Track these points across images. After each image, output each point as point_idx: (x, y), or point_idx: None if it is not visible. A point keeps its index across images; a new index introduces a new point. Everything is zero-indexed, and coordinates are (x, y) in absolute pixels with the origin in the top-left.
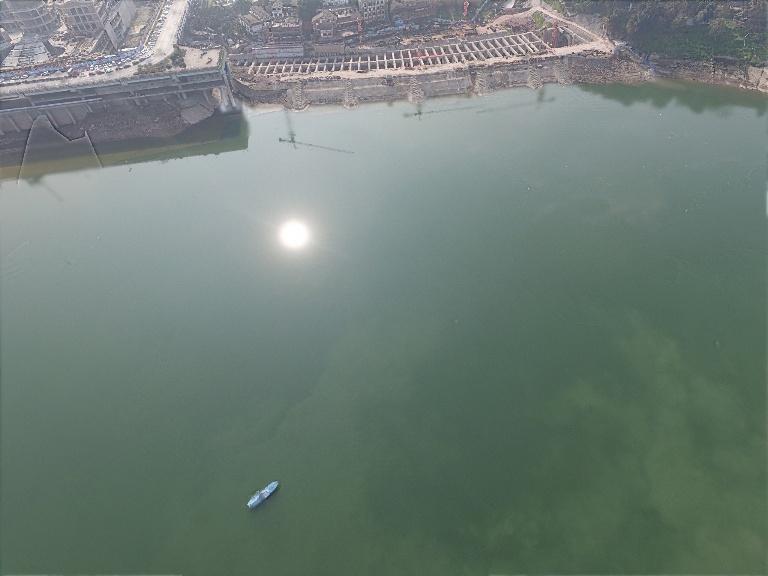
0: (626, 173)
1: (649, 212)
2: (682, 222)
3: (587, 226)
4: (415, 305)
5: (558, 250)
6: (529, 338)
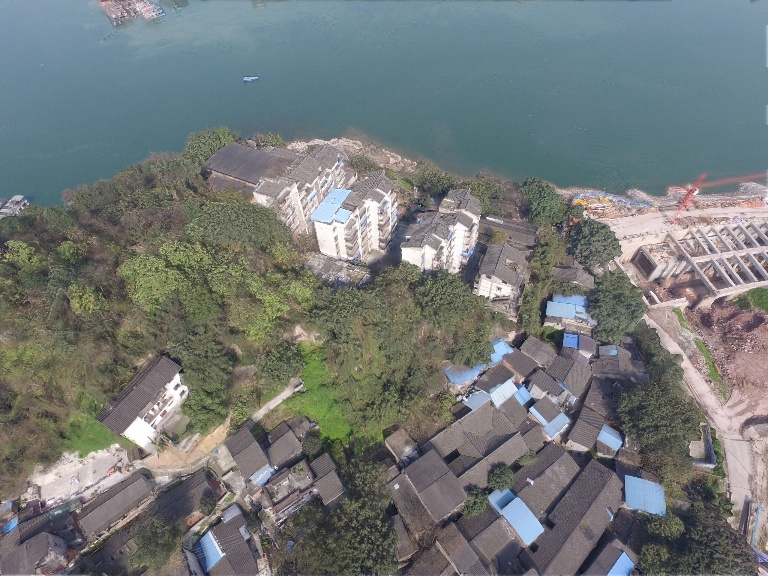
0: (588, 85)
1: (576, 68)
2: (562, 53)
3: (627, 51)
4: (725, 38)
5: (645, 47)
6: (658, 24)
